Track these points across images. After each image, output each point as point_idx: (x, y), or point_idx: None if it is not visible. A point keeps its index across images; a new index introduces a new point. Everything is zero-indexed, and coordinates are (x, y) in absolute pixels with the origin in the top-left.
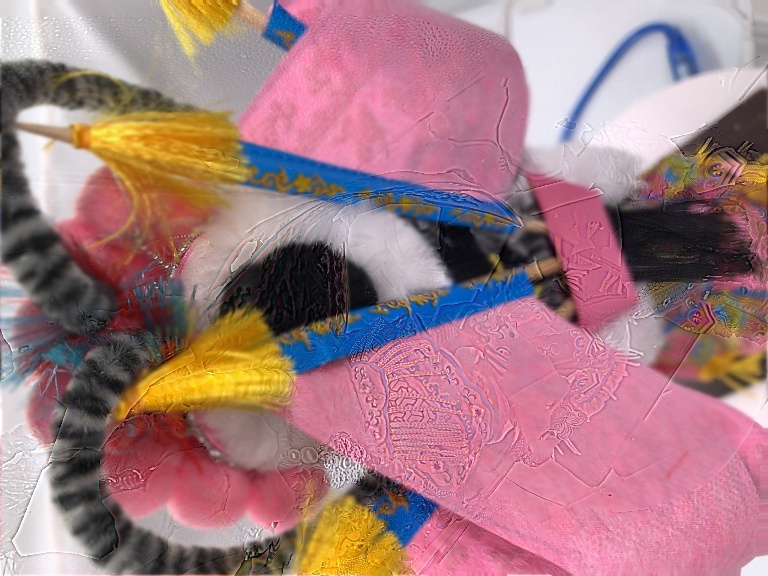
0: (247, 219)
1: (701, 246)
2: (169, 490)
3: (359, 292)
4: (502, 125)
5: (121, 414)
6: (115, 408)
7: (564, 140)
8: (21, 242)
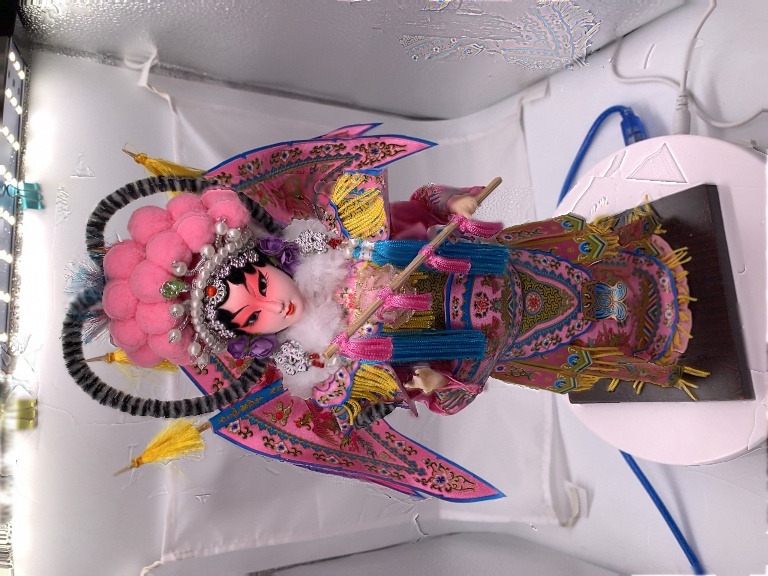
0: None
1: None
2: None
3: None
4: None
5: (67, 8)
6: None
7: None
8: None
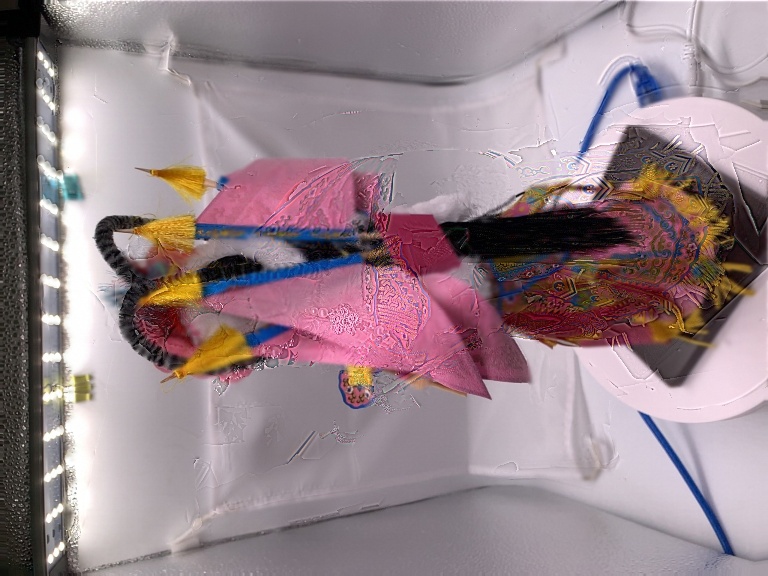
0: (409, 99)
1: (562, 242)
2: (225, 318)
3: (403, 208)
4: (699, 7)
5: (140, 305)
6: (138, 303)
7: (763, 31)
8: (240, 110)
